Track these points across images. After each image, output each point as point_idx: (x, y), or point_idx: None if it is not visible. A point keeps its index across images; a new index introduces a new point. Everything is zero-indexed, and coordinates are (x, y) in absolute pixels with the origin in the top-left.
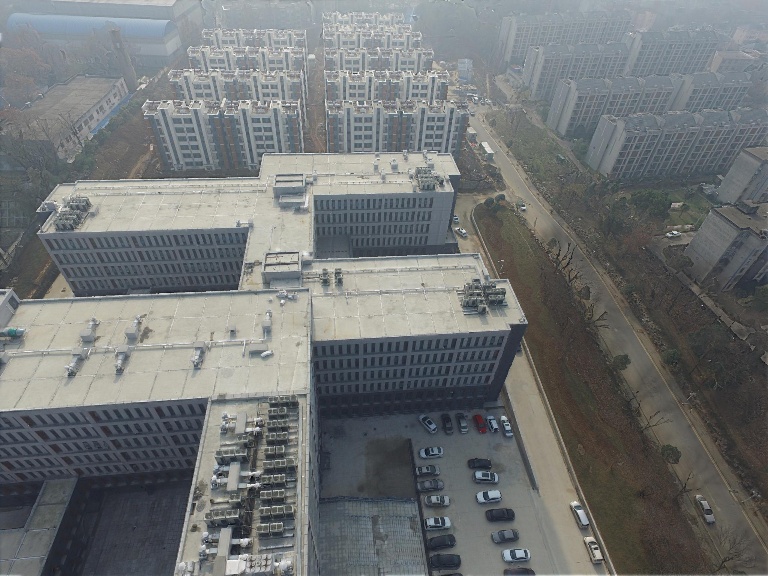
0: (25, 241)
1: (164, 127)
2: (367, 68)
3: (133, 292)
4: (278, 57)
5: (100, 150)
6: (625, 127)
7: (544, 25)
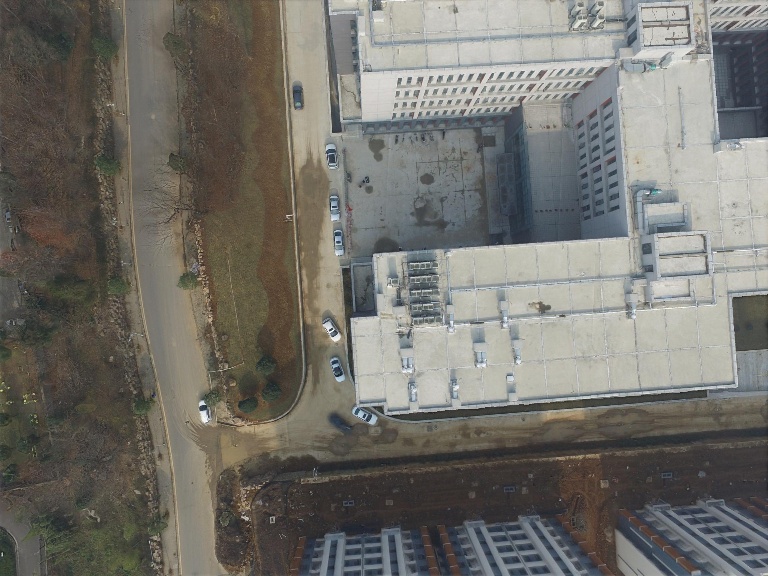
0: None
1: None
2: None
3: None
4: None
5: None
6: None
7: None
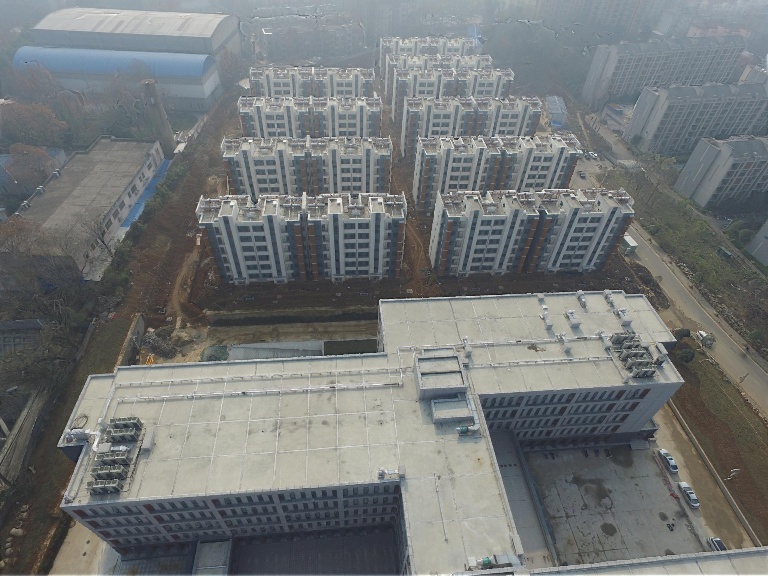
0: (38, 430)
1: (225, 237)
2: (459, 123)
3: (204, 549)
4: (351, 111)
5: (135, 253)
6: None
7: (649, 55)
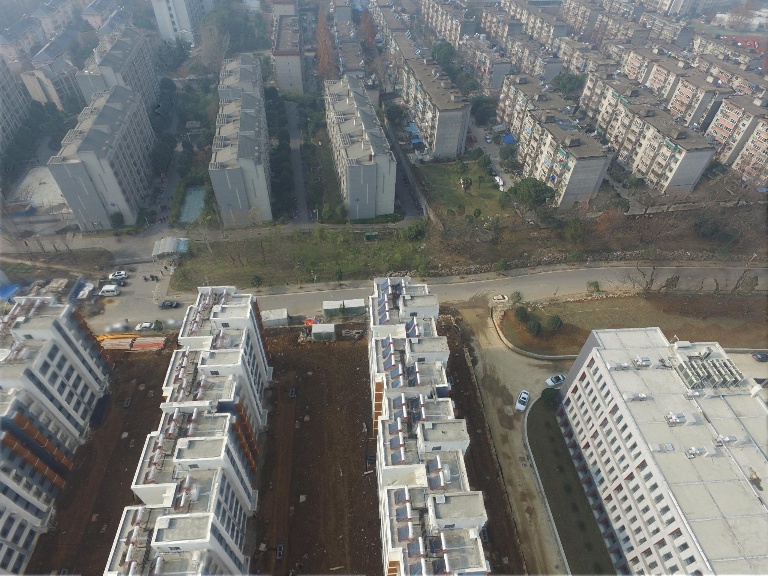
0: None
1: None
2: None
3: None
4: None
5: None
6: (387, 158)
7: None
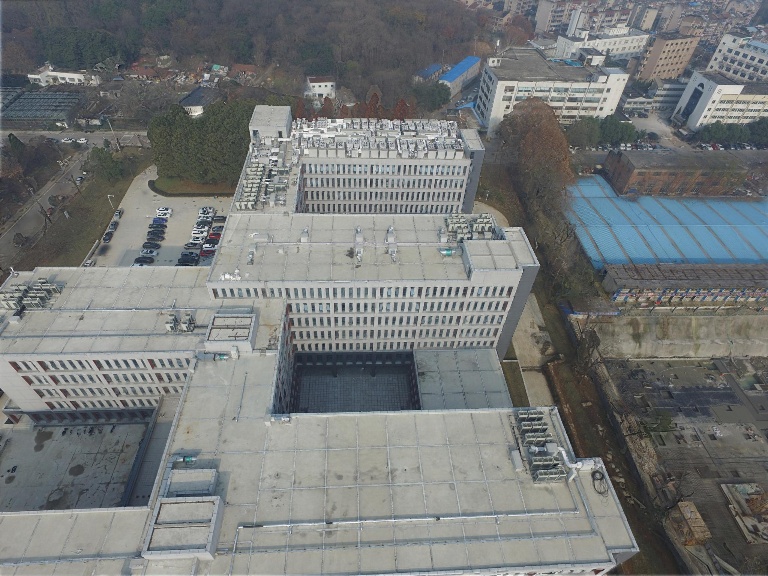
0: None
1: None
2: None
3: None
4: None
5: None
6: None
7: None
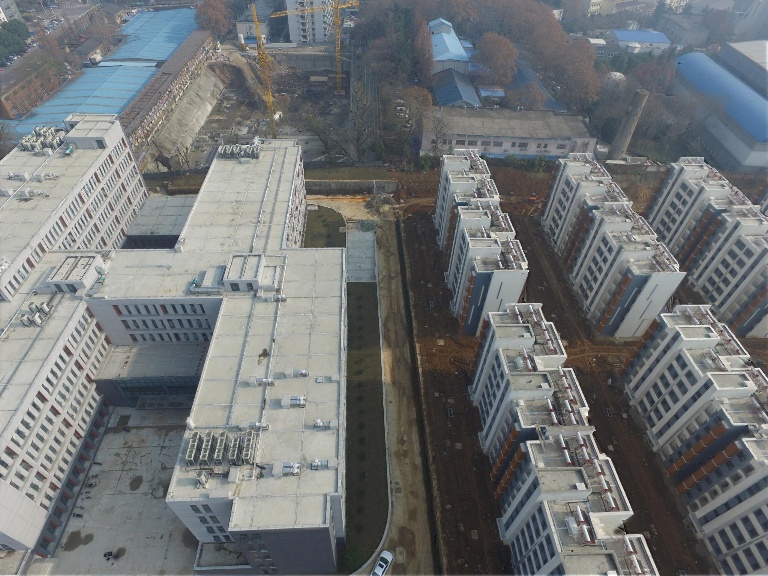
0: (310, 166)
1: (441, 177)
2: None
3: None
4: (754, 247)
5: None
6: None
7: None
